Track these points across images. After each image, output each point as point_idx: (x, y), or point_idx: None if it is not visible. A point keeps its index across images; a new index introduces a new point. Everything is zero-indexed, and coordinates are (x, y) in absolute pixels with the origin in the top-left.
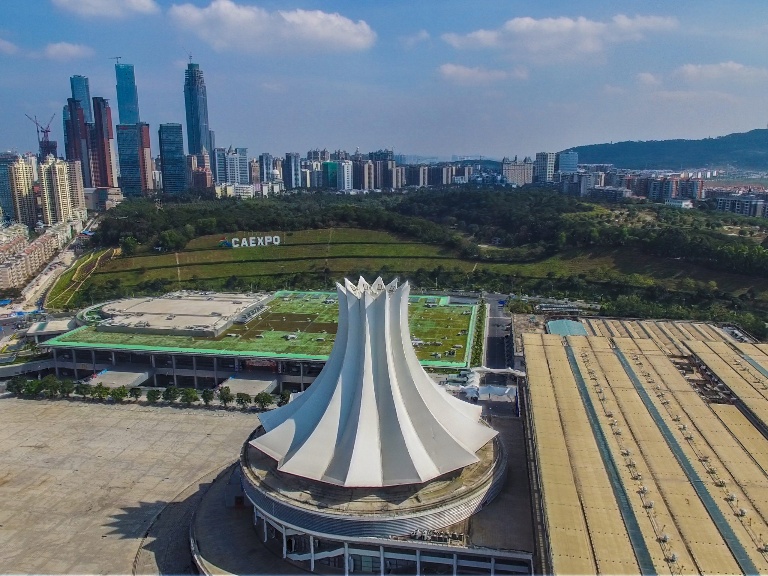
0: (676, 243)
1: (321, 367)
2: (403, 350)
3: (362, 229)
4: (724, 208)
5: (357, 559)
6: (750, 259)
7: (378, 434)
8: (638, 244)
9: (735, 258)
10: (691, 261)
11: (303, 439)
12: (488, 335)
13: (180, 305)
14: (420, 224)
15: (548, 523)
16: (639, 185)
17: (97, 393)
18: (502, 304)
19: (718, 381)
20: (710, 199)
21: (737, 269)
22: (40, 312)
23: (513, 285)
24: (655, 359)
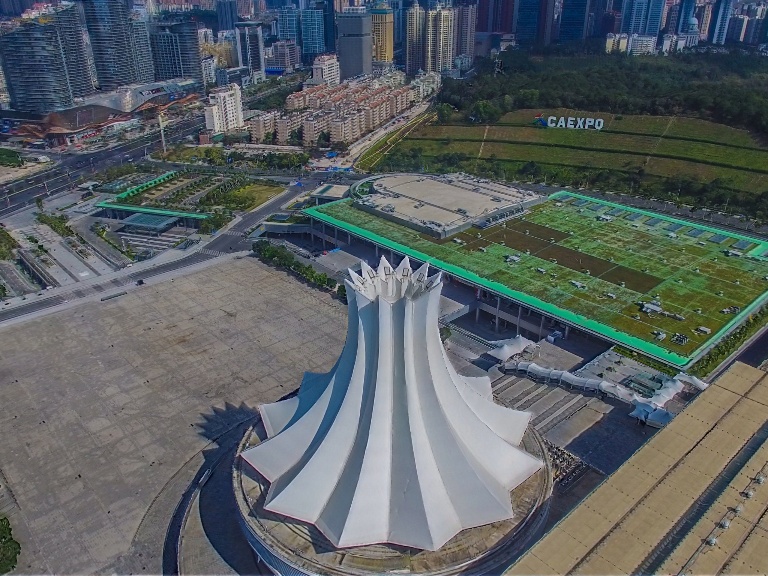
0: None
1: None
2: (404, 371)
3: (714, 122)
4: None
5: None
6: None
7: (346, 459)
8: None
9: None
10: None
11: None
12: None
13: (441, 192)
14: None
15: None
16: None
17: None
18: None
19: None
20: None
21: None
22: (350, 170)
23: None
24: None
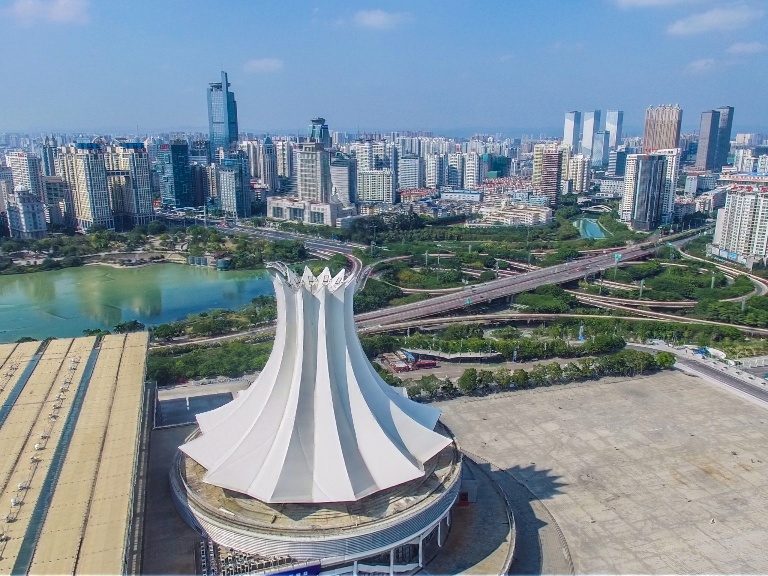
0: None
1: None
2: None
3: None
4: None
5: None
6: None
7: None
8: None
9: None
10: None
11: None
12: None
13: None
14: None
15: None
16: None
17: None
18: None
19: None
20: None
21: None
22: None
23: None
24: None
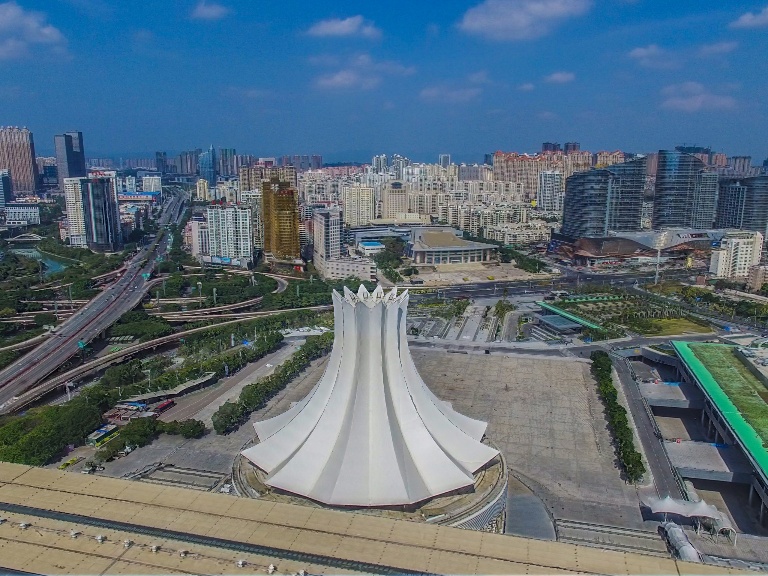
0: None
1: None
2: (341, 362)
3: None
4: None
5: None
6: None
7: None
8: None
9: None
10: None
11: None
12: None
13: None
14: None
15: None
16: None
17: None
18: None
19: None
20: None
21: None
22: None
23: None
24: None
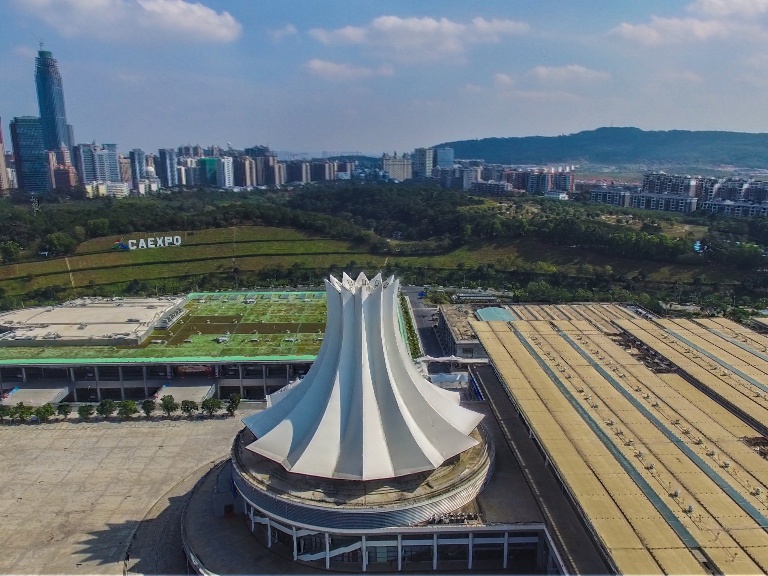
0: (572, 232)
1: (259, 368)
2: (396, 343)
3: (267, 227)
4: (597, 199)
5: (372, 551)
6: (638, 245)
7: (381, 427)
8: (537, 234)
9: (625, 244)
10: (586, 248)
11: (303, 439)
12: (417, 326)
13: (88, 313)
14: (327, 220)
15: (573, 492)
16: (517, 179)
17: (18, 414)
18: (420, 296)
19: (656, 354)
20: (583, 191)
21: (626, 254)
22: None
23: (426, 277)
24: (596, 338)
